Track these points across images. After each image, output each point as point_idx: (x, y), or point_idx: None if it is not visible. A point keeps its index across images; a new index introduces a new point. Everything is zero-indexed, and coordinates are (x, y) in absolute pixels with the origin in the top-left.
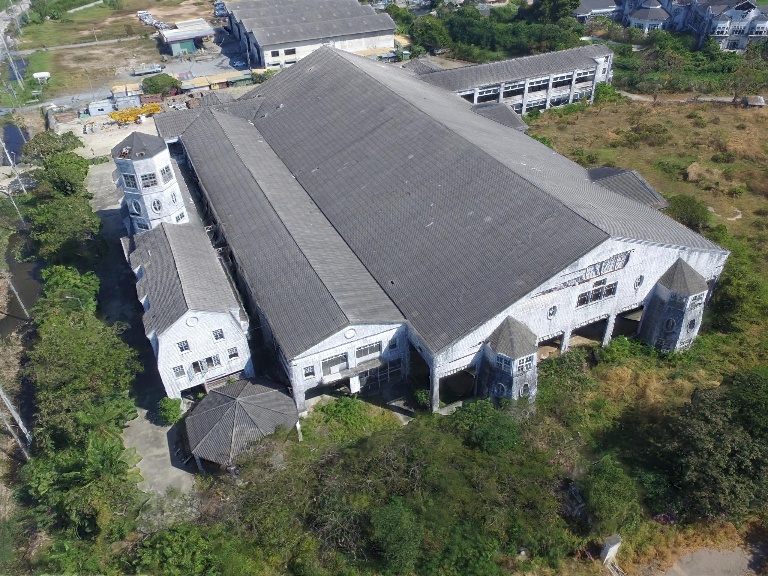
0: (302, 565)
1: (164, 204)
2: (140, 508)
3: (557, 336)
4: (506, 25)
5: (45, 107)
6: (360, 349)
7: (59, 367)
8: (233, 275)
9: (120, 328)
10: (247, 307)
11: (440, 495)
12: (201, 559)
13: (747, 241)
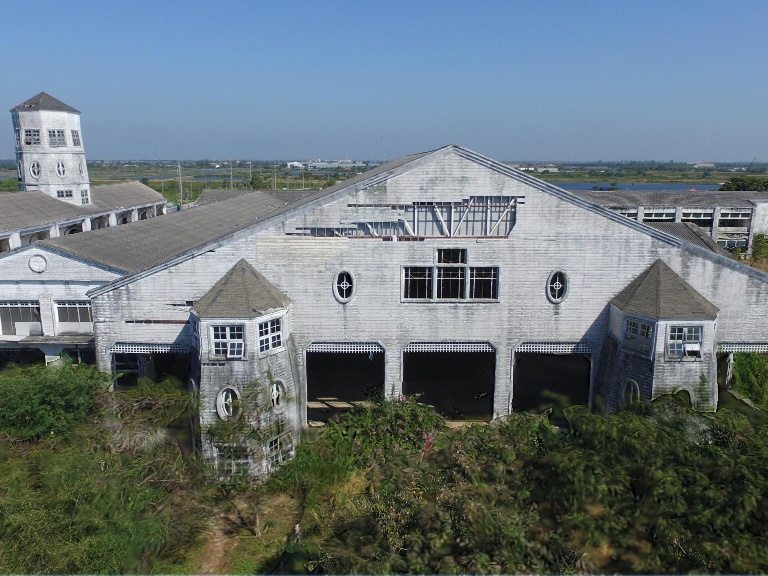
0: None
1: (44, 169)
2: None
3: (369, 353)
4: None
5: None
6: (64, 306)
7: None
8: None
9: None
10: None
11: None
12: None
13: None
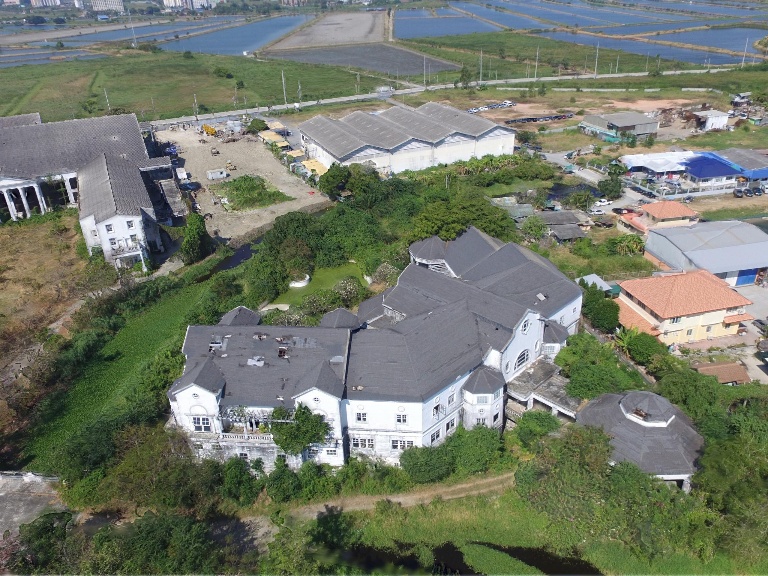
0: None
1: None
2: None
3: None
4: None
5: None
6: None
7: None
8: None
9: None
10: None
11: None
12: None
13: None
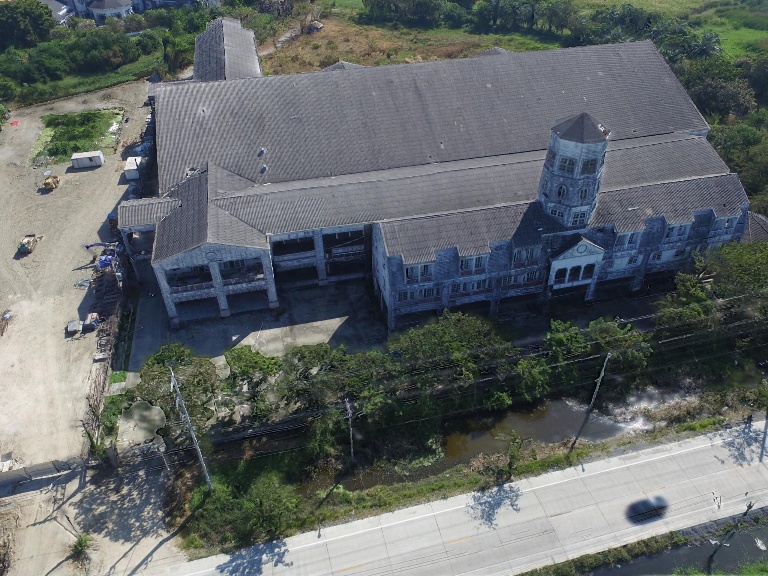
0: None
1: None
2: None
3: None
4: None
5: None
6: None
7: None
8: None
9: None
10: None
11: None
12: None
13: None
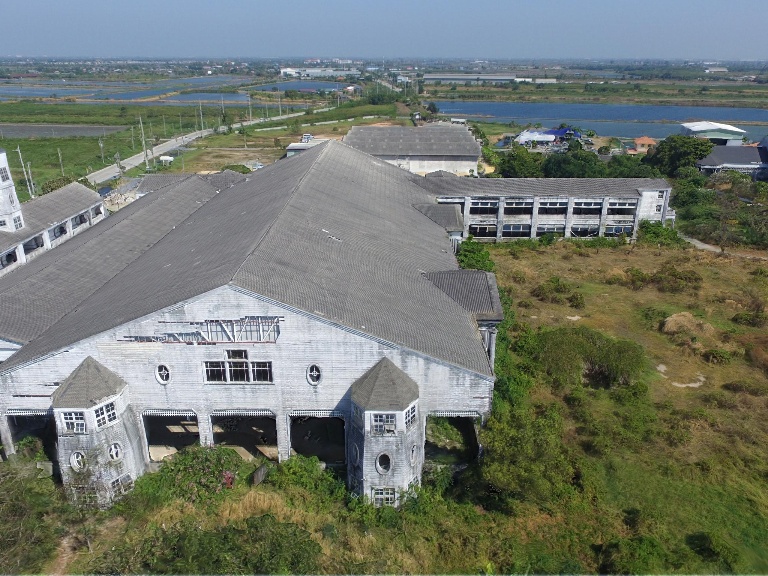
0: None
1: None
2: None
3: (187, 416)
4: None
5: None
6: None
7: None
8: None
9: None
10: None
11: None
12: None
13: (669, 413)
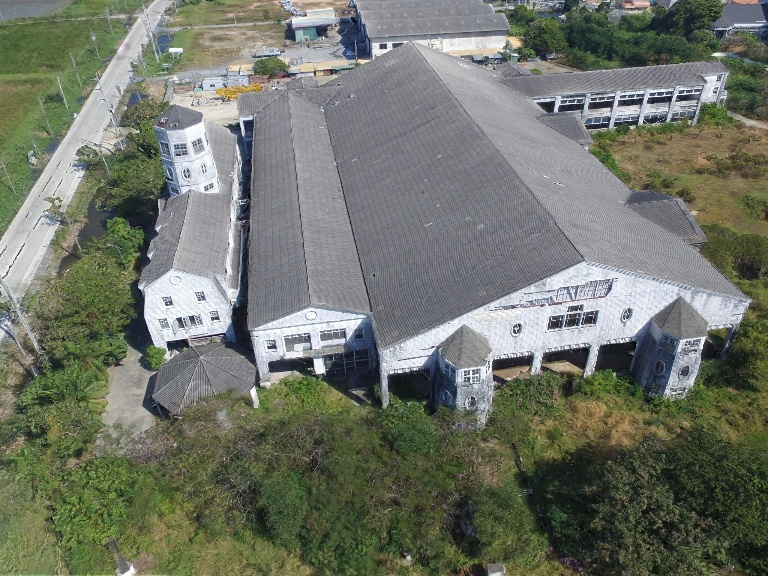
0: (205, 516)
1: (193, 173)
2: (92, 434)
3: (525, 356)
4: (634, 34)
5: (169, 79)
6: (324, 333)
7: (66, 301)
8: (244, 246)
9: (131, 277)
10: (242, 277)
11: (333, 481)
12: (116, 488)
13: None
